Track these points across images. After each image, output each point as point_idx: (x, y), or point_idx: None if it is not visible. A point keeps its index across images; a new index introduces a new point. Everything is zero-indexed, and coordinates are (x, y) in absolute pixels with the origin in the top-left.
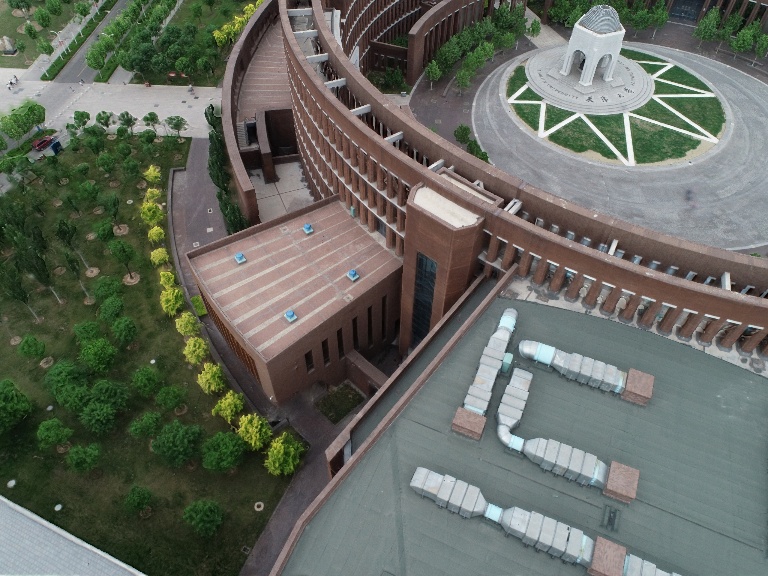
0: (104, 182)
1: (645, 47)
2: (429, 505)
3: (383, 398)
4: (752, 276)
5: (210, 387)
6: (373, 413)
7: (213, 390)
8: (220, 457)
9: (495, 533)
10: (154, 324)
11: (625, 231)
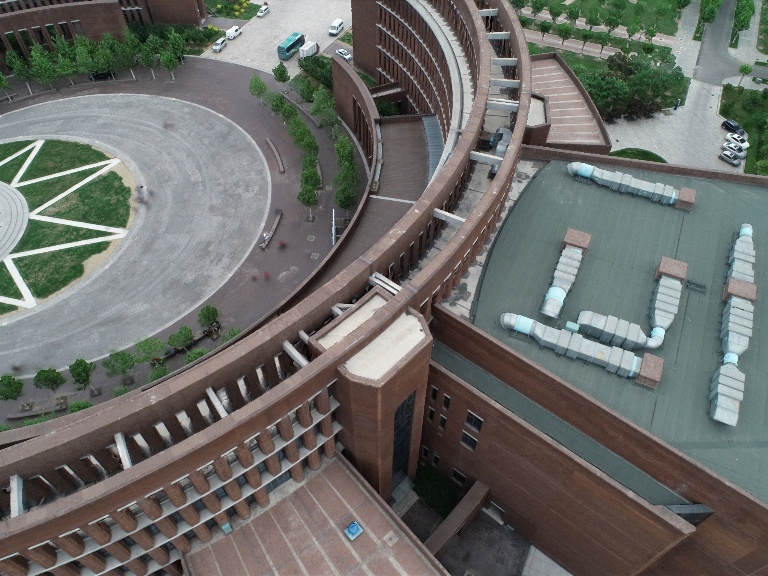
0: None
1: None
2: None
3: None
4: (475, 139)
5: None
6: None
7: None
8: None
9: (740, 366)
10: None
11: (437, 196)
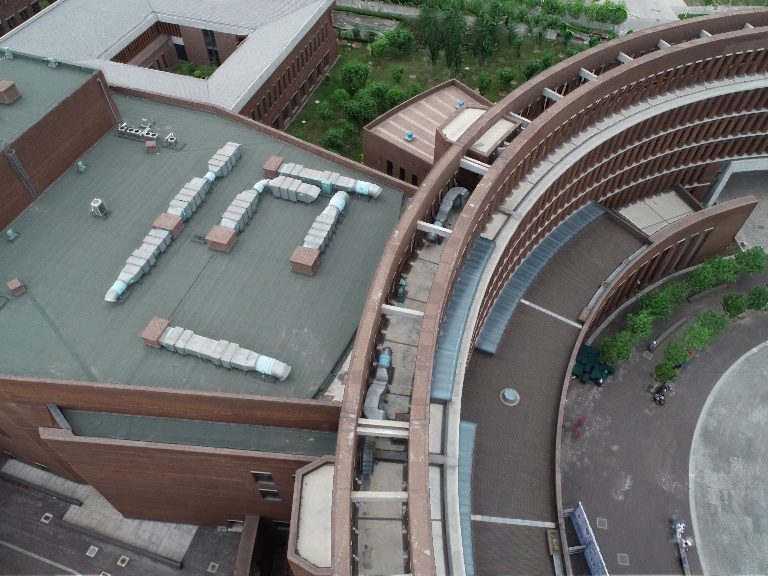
0: None
1: None
2: None
3: None
4: None
5: None
6: None
7: None
8: None
9: None
10: None
11: None
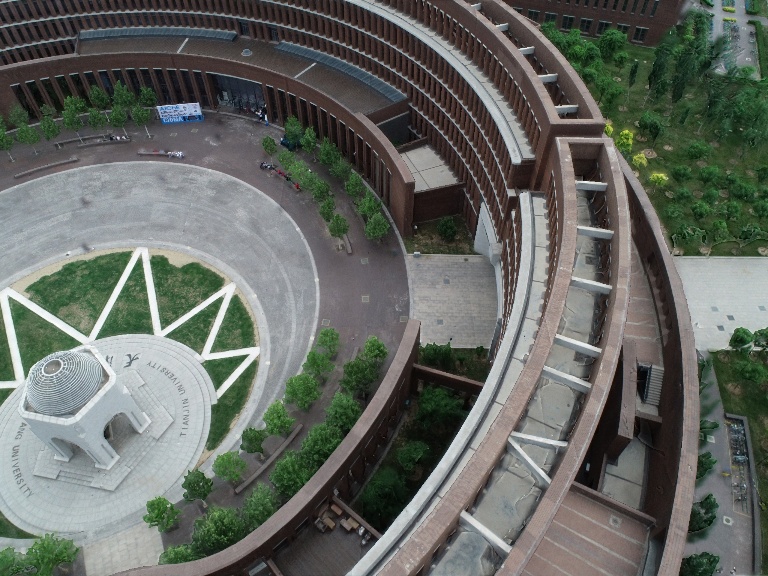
0: None
1: None
2: None
3: None
4: None
5: None
6: None
7: None
8: None
9: None
10: None
11: None
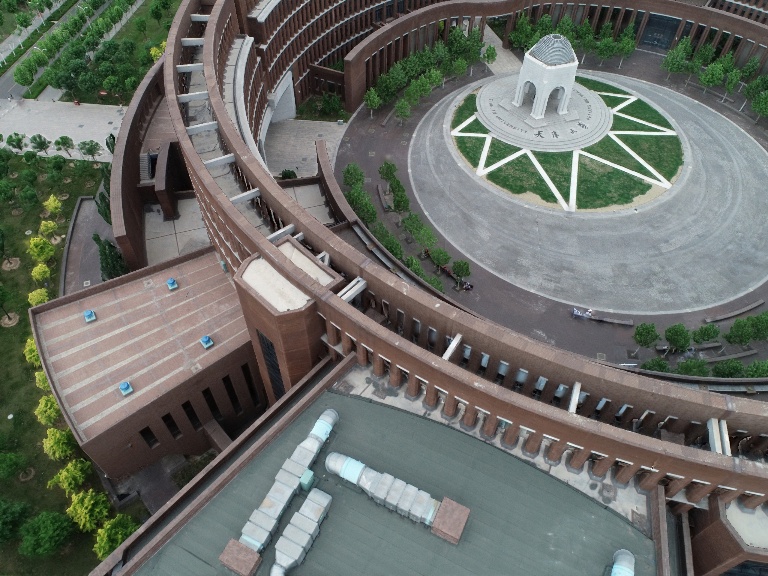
0: (7, 209)
1: (609, 77)
2: None
3: (175, 508)
4: (605, 389)
5: (55, 454)
6: (161, 526)
7: (57, 457)
8: (37, 543)
9: None
10: (21, 373)
11: (466, 327)
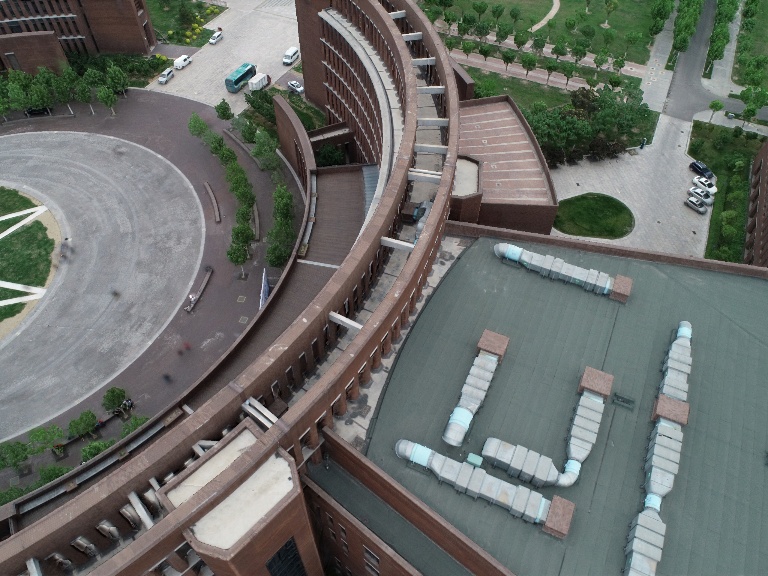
0: None
1: None
2: (655, 575)
3: None
4: (388, 222)
5: None
6: None
7: None
8: None
9: (664, 507)
10: None
11: (332, 299)
